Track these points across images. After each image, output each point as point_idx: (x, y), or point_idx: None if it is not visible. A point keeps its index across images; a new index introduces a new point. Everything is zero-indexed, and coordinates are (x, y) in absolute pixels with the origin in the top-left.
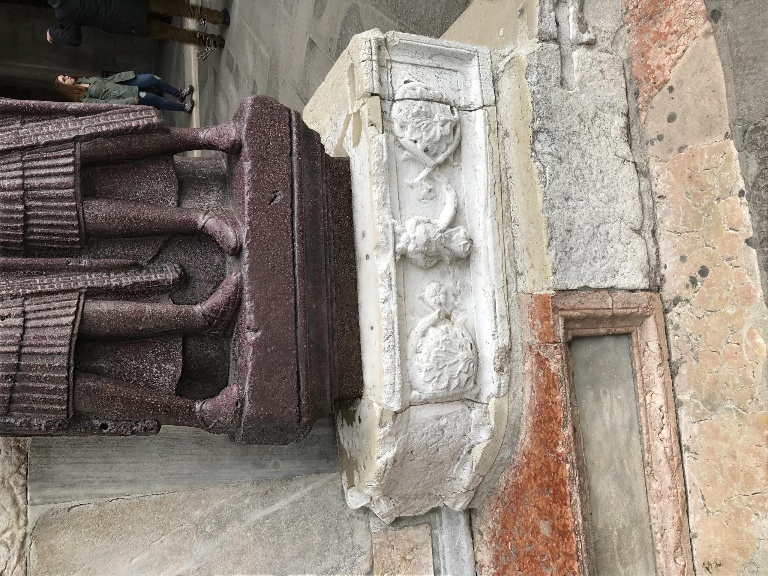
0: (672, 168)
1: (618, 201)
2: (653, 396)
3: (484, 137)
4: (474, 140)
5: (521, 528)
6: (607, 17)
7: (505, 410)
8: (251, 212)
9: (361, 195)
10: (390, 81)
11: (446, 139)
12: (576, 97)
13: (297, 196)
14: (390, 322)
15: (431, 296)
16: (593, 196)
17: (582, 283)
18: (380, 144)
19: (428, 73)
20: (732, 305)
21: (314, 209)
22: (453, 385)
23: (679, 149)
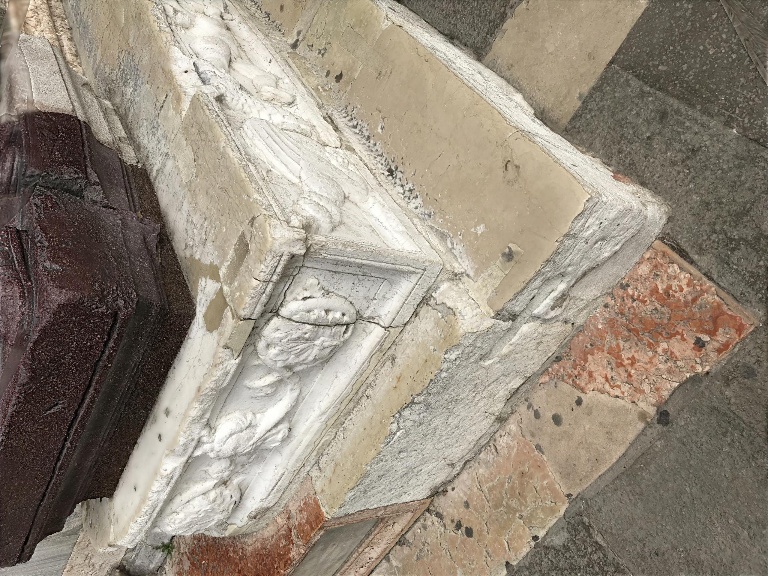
0: (520, 447)
1: (453, 446)
2: (371, 550)
3: (366, 357)
4: (355, 351)
5: (215, 570)
6: (599, 284)
7: (242, 531)
8: (13, 423)
9: (184, 379)
10: (286, 289)
11: (318, 359)
12: (488, 368)
13: (88, 402)
14: (152, 507)
15: (215, 473)
16: (431, 446)
17: (364, 508)
18: (226, 373)
19: (346, 280)
20: (463, 573)
21: (115, 383)
22: (197, 532)
23: (538, 445)
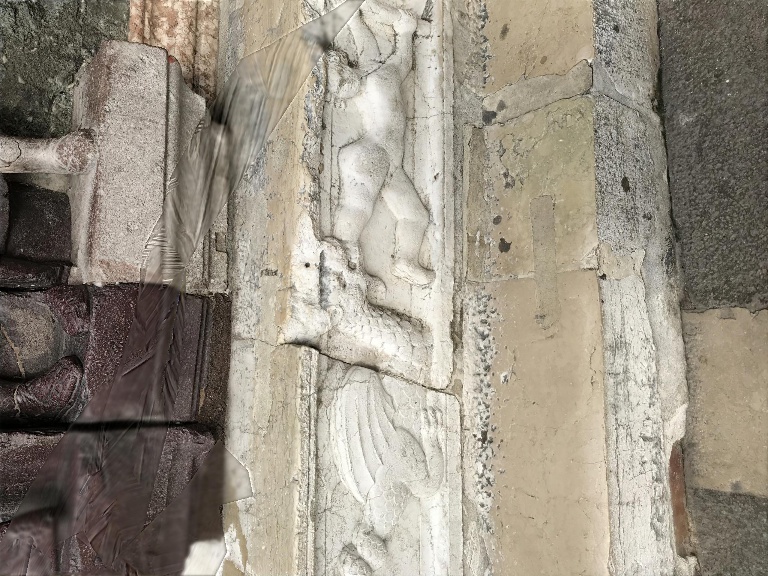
0: None
1: None
2: None
3: None
4: None
5: None
6: None
7: None
8: None
9: None
10: None
11: None
12: None
13: None
14: None
15: None
16: None
17: None
18: None
19: None
20: None
21: None
22: None
23: None
